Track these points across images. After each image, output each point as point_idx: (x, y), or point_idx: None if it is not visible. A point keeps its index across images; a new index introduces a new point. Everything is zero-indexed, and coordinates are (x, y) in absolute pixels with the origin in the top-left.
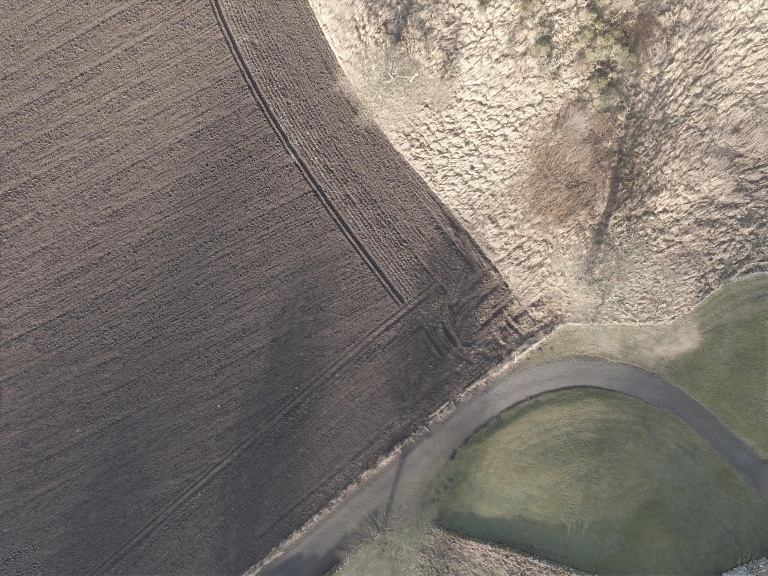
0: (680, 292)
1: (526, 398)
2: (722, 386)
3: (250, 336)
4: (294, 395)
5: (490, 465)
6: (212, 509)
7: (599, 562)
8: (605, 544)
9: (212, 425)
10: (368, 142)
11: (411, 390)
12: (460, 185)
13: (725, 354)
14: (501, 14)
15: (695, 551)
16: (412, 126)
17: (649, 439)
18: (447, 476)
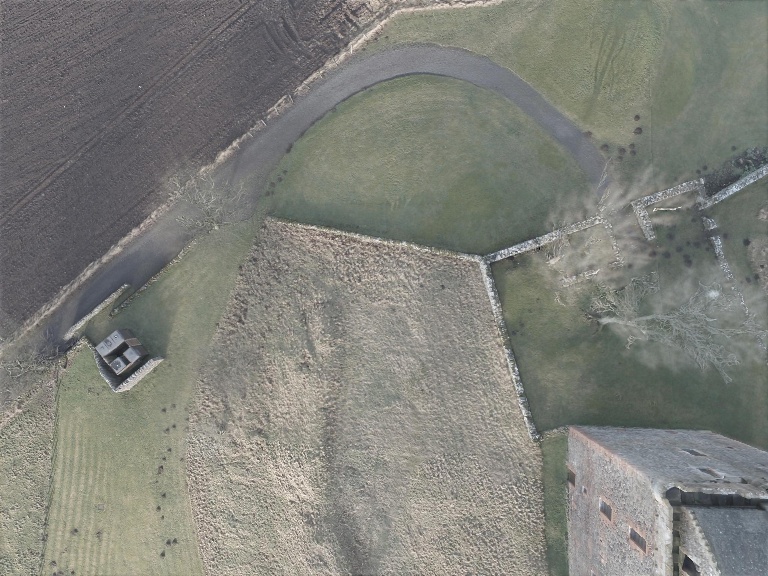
0: None
1: (361, 89)
2: (547, 61)
3: (97, 36)
4: (138, 94)
5: (322, 153)
6: (54, 208)
7: (418, 232)
8: (425, 215)
9: (57, 125)
10: None
11: (251, 85)
12: None
13: (550, 29)
14: None
15: (511, 218)
16: None
17: (474, 117)
18: (282, 169)
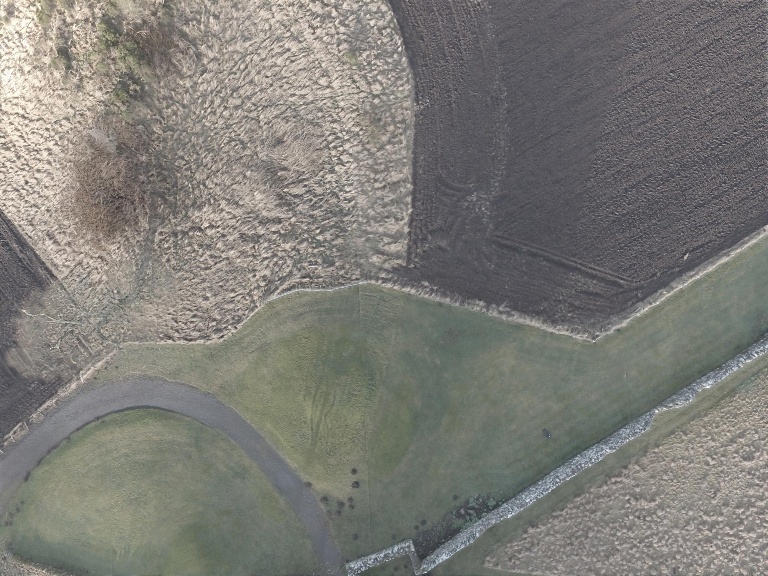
0: (229, 310)
1: (94, 419)
2: (267, 407)
3: None
4: None
5: (55, 488)
6: None
7: None
8: (147, 570)
9: None
10: None
11: None
12: (17, 200)
13: (268, 374)
14: (27, 25)
15: None
16: None
17: (198, 461)
18: (20, 499)
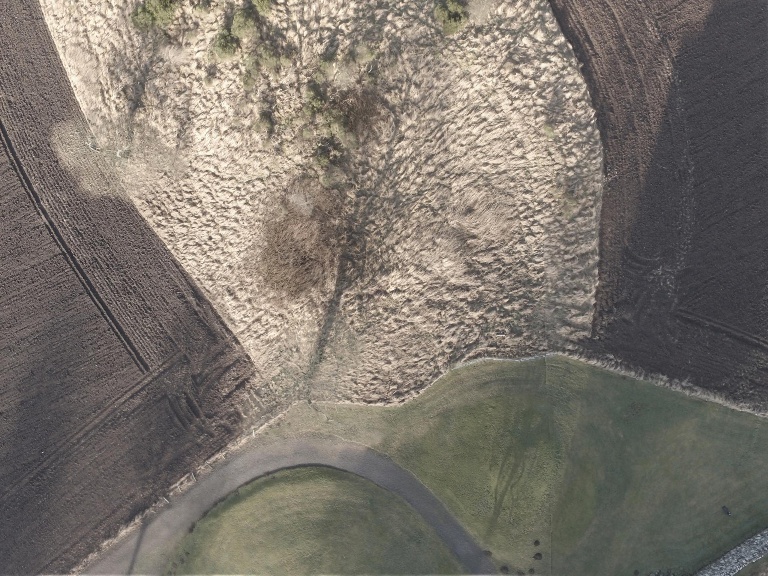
0: (411, 374)
1: (264, 474)
2: (447, 473)
3: None
4: (40, 459)
5: (223, 541)
6: None
7: None
8: None
9: None
10: (115, 206)
11: (153, 460)
12: (199, 255)
13: (451, 440)
14: (228, 86)
15: None
16: (153, 193)
17: (375, 524)
18: (185, 550)
